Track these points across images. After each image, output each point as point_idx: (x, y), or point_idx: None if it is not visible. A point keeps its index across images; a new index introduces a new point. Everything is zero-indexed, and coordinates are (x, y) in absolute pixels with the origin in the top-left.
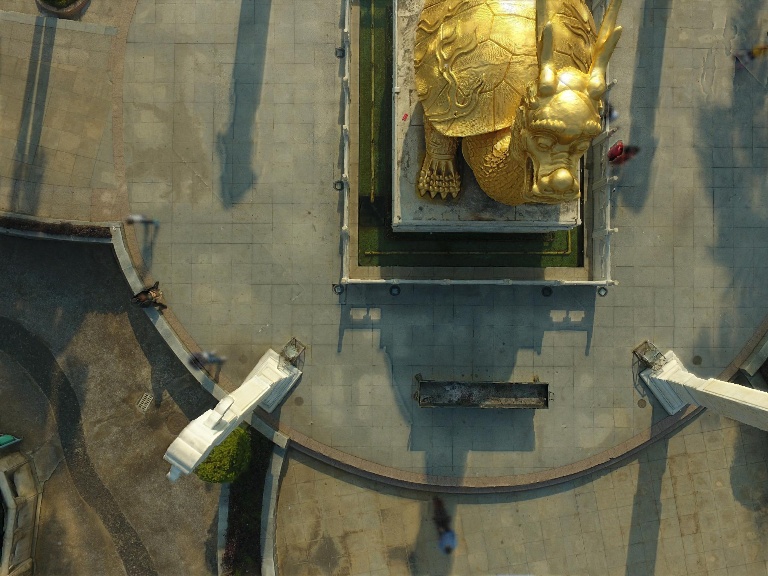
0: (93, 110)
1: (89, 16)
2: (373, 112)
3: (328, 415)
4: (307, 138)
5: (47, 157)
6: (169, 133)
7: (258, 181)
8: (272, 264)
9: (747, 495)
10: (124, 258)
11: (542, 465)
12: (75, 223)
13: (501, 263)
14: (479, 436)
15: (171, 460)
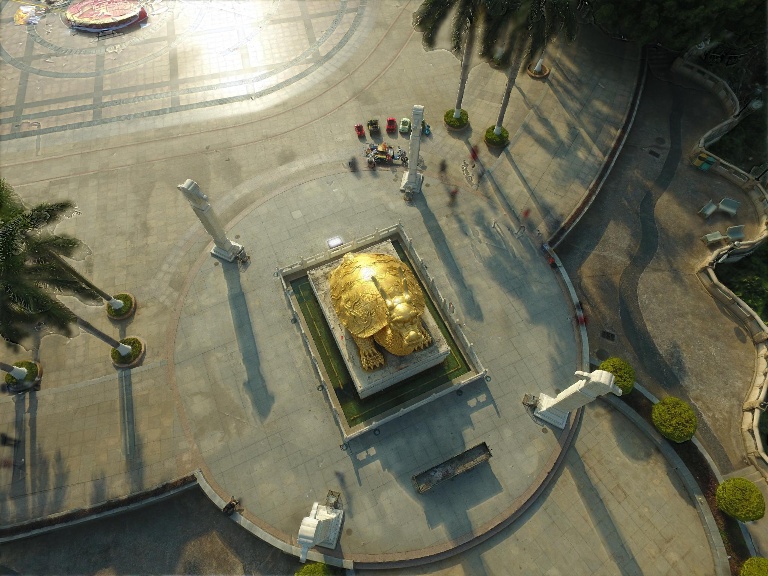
0: (164, 410)
1: (147, 360)
2: (323, 342)
3: (371, 532)
4: (293, 371)
5: (142, 450)
6: (213, 403)
7: (274, 406)
8: (299, 451)
9: (637, 457)
10: (208, 489)
11: (513, 498)
12: (171, 482)
13: (428, 389)
14: (467, 498)
15: (302, 539)
